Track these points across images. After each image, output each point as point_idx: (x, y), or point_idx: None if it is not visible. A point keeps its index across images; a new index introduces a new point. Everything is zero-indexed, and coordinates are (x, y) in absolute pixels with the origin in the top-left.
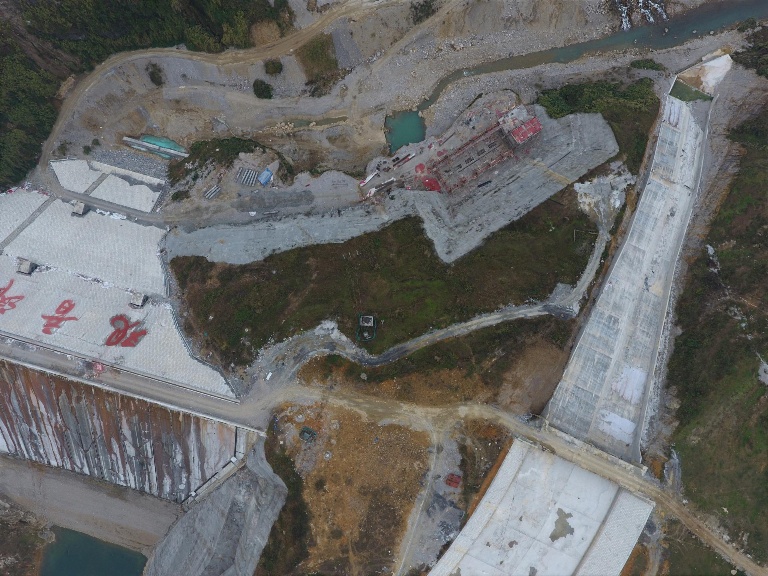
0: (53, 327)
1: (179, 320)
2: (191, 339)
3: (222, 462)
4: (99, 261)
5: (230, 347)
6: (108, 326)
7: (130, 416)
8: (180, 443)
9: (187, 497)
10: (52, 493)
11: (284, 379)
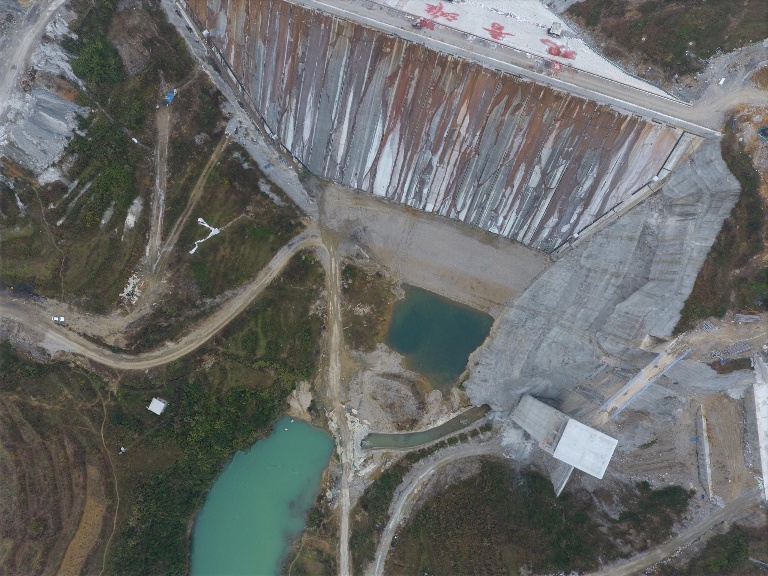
0: (498, 36)
1: (597, 50)
2: (619, 61)
3: (636, 186)
4: (502, 3)
5: (675, 58)
6: (542, 44)
7: (564, 128)
8: (601, 162)
9: (562, 243)
10: (419, 241)
11: (738, 84)
